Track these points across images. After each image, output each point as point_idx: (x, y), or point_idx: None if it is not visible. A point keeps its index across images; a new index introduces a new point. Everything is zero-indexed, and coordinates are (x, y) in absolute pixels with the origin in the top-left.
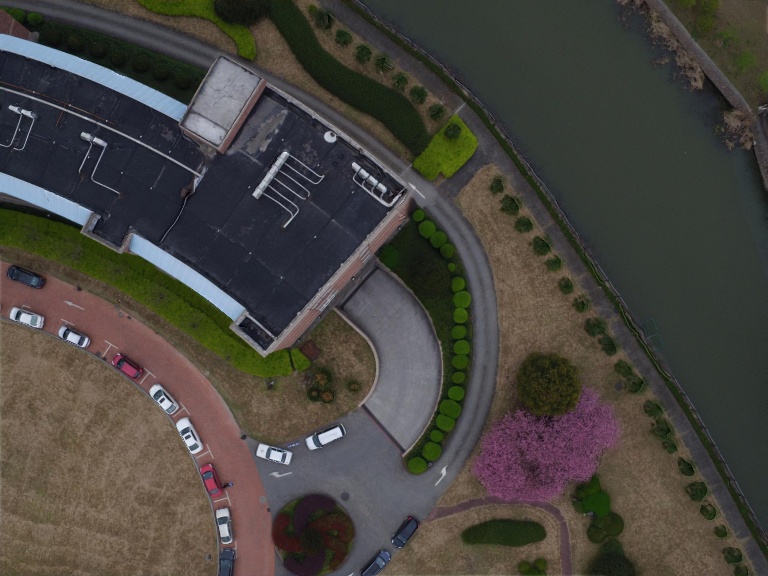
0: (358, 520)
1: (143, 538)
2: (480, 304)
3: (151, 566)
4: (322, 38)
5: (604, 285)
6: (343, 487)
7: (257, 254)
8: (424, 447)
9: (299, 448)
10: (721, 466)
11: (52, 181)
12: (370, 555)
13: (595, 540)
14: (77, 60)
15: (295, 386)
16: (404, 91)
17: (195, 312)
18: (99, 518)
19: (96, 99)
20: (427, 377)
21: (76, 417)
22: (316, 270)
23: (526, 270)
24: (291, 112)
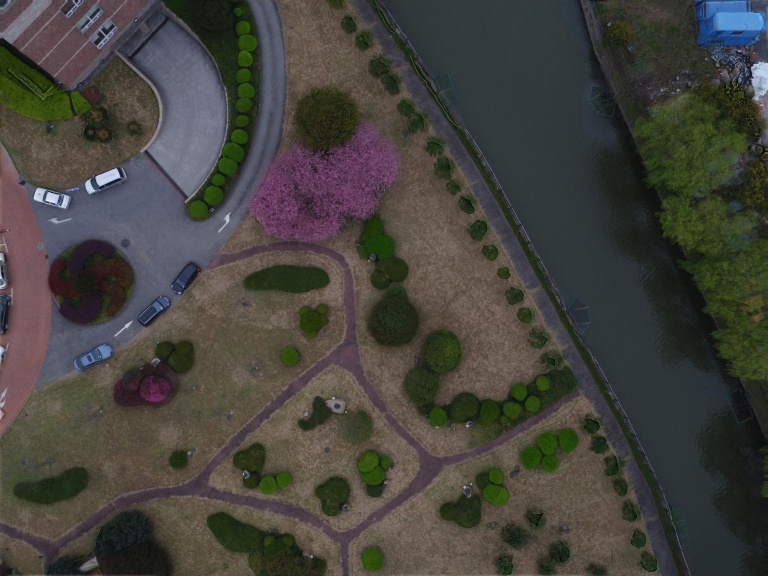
0: (138, 267)
1: None
2: (267, 51)
3: None
4: None
5: (393, 32)
6: (124, 234)
7: None
8: (205, 191)
9: (79, 194)
10: (509, 214)
11: None
12: (150, 302)
13: (378, 285)
14: None
15: (76, 131)
16: None
17: None
18: None
19: None
20: (213, 125)
21: None
22: None
23: (314, 17)
24: None
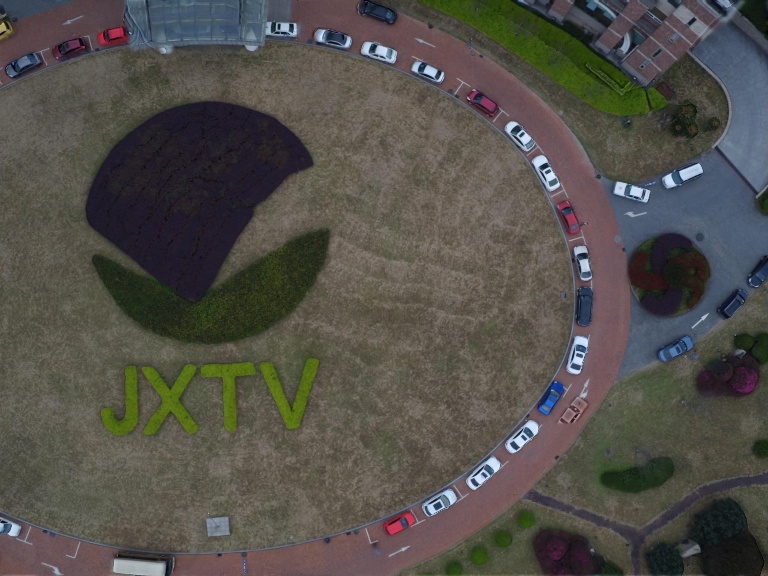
0: (713, 261)
1: (498, 276)
2: None
3: (507, 304)
4: None
5: None
6: (698, 228)
7: None
8: None
9: (654, 188)
10: None
11: None
12: (726, 295)
13: None
14: None
15: (650, 126)
16: None
17: (550, 50)
18: (454, 255)
19: None
20: None
21: (429, 154)
22: None
23: None
24: None
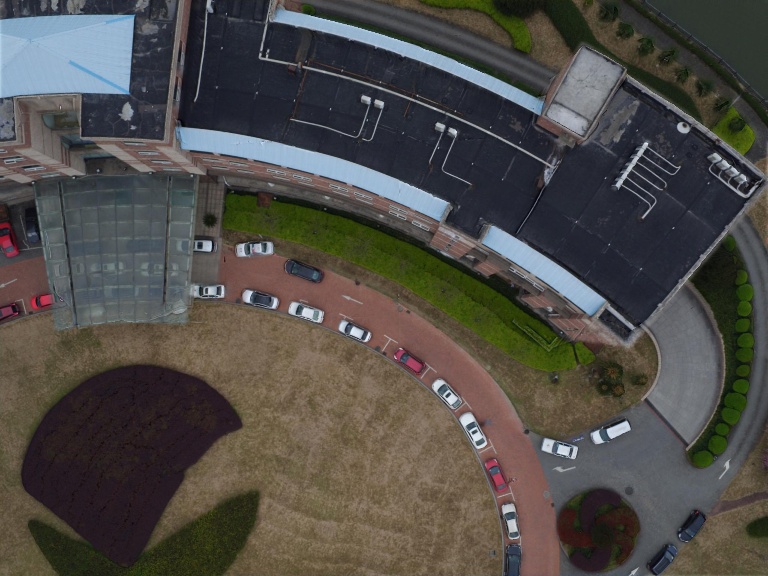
0: (643, 514)
1: (427, 534)
2: (760, 297)
3: (436, 562)
4: (596, 31)
5: None
6: (627, 481)
7: (615, 245)
8: (710, 440)
9: (582, 442)
10: None
11: (403, 172)
12: (656, 549)
13: None
14: (422, 50)
15: (578, 380)
16: (683, 84)
17: (477, 306)
18: (382, 514)
19: (443, 89)
20: (707, 370)
21: (357, 412)
22: (674, 261)
23: None
24: (642, 103)
